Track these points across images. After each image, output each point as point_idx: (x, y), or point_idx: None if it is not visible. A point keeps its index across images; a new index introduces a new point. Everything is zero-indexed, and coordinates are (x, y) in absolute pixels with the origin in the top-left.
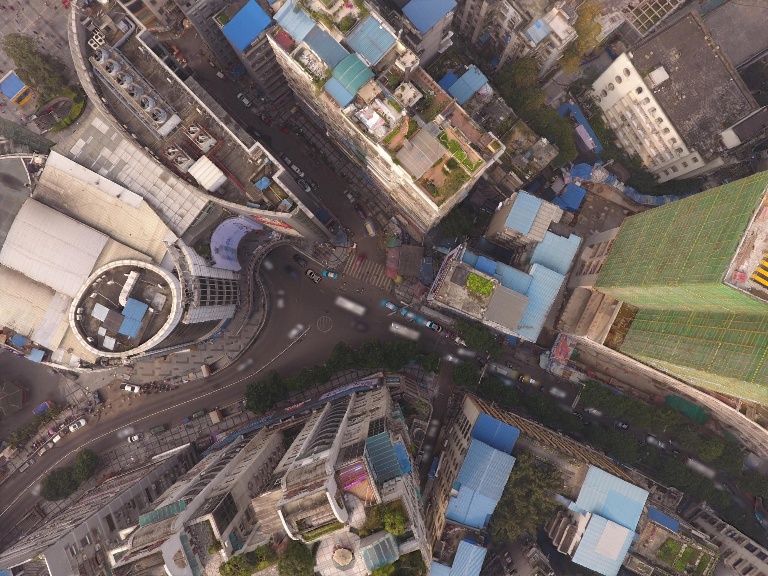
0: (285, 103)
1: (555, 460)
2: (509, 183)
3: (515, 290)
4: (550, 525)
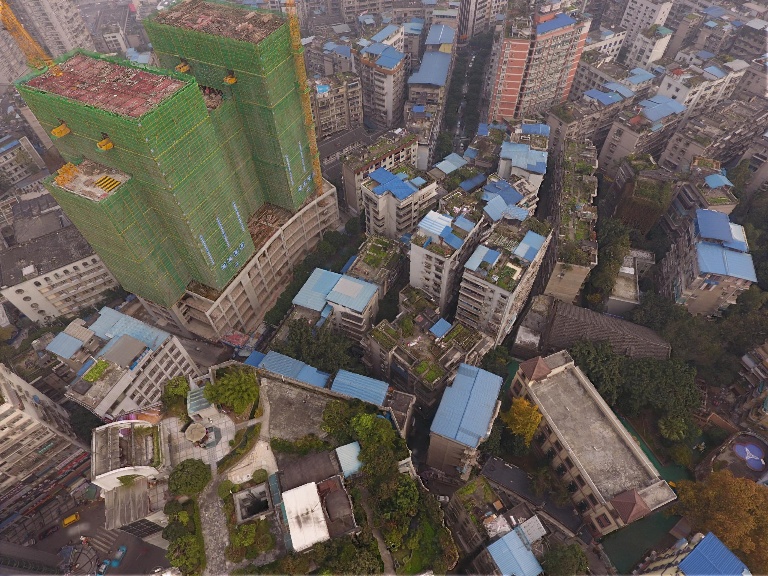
0: None
1: None
2: (70, 375)
3: None
4: None
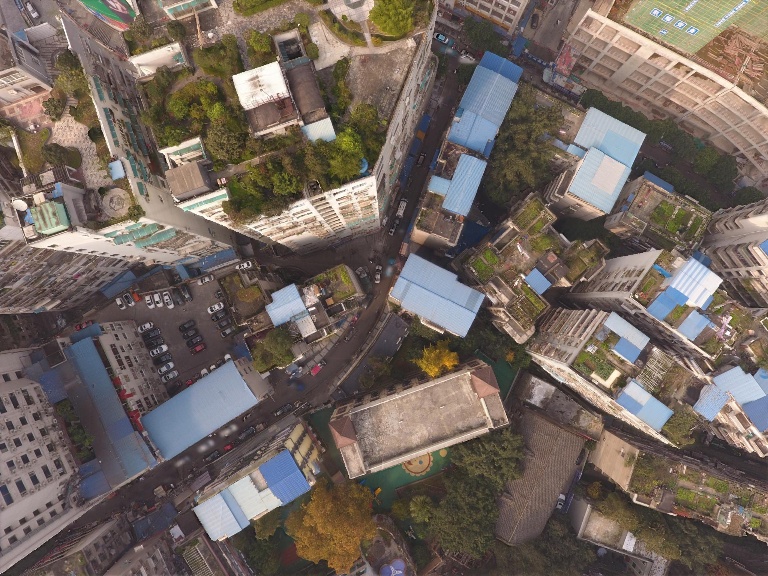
0: None
1: None
2: None
3: None
4: (548, 191)
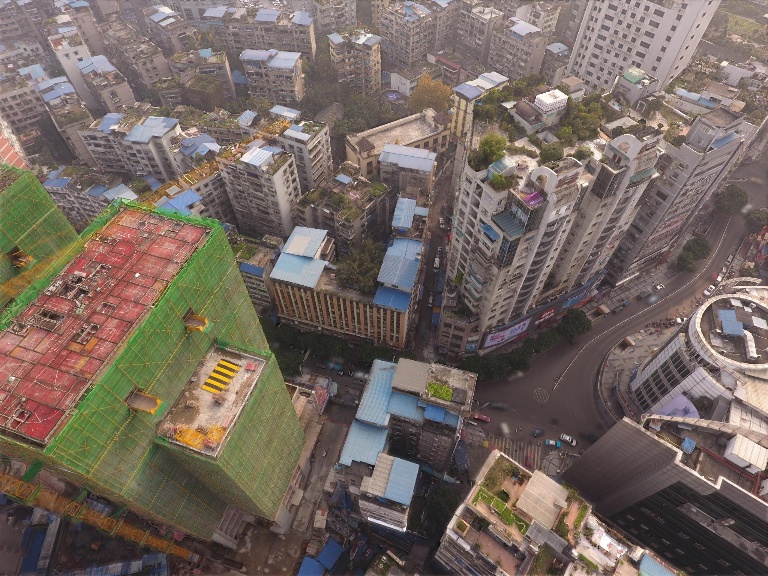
0: None
1: (340, 291)
2: None
3: (402, 397)
4: None
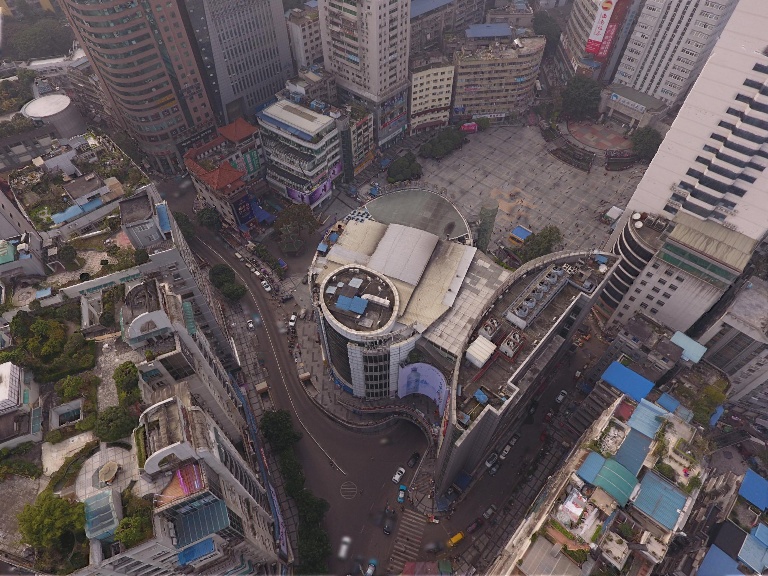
0: (570, 435)
1: None
2: None
3: None
4: None
